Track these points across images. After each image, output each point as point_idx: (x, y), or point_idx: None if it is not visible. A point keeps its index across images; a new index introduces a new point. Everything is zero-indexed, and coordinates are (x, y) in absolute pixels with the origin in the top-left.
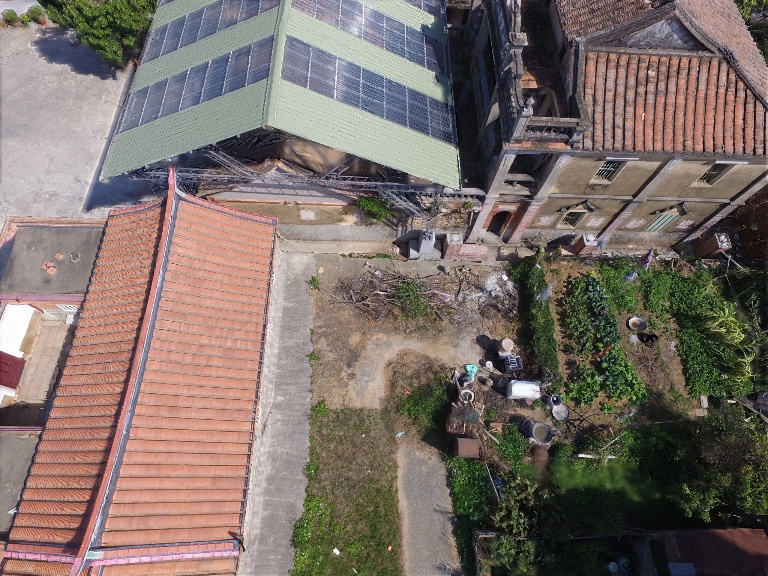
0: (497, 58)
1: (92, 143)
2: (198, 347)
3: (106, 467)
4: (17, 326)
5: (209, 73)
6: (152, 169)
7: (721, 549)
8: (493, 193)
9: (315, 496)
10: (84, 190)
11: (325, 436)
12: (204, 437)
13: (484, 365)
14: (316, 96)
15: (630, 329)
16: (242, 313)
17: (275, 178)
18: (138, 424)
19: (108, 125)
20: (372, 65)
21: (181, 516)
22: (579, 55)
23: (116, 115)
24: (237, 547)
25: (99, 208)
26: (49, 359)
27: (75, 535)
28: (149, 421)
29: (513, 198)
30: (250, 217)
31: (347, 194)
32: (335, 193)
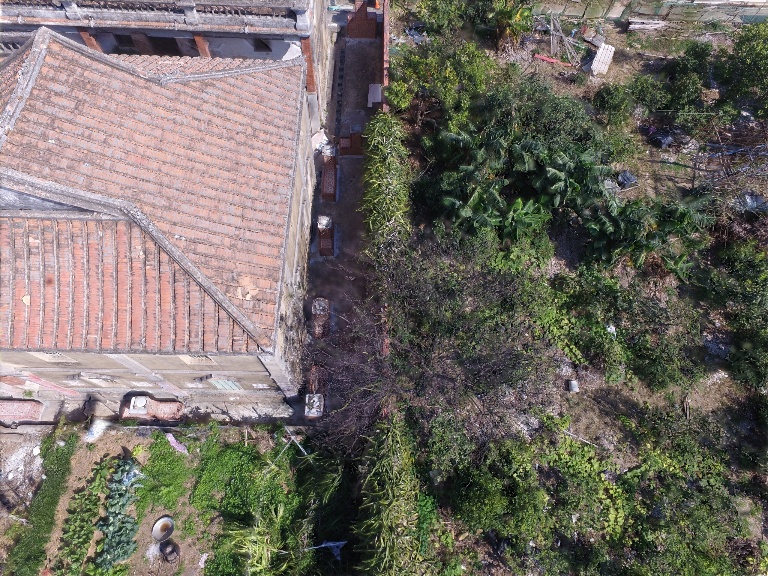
0: None
1: None
2: None
3: None
4: None
5: None
6: None
7: None
8: None
9: None
10: None
11: None
12: None
13: None
14: None
15: (153, 535)
16: None
17: None
18: None
19: None
20: None
21: None
22: None
23: None
24: None
25: None
26: None
27: None
28: None
29: None
30: None
31: None
32: None
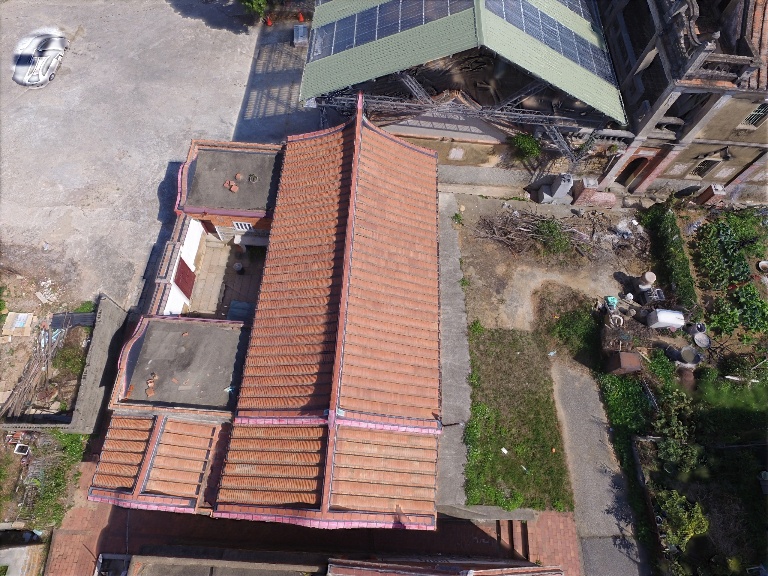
0: (660, 7)
1: (233, 90)
2: (389, 254)
3: (337, 342)
4: (193, 241)
5: (402, 8)
6: (344, 94)
7: None
8: (642, 135)
9: (481, 402)
10: (230, 131)
11: (483, 351)
12: (403, 331)
13: (623, 298)
14: (512, 27)
15: (760, 271)
16: (419, 230)
17: (453, 108)
18: (352, 312)
19: (246, 74)
20: (545, 8)
21: (394, 394)
22: (750, 1)
23: (252, 66)
24: (440, 426)
25: None
26: (215, 276)
27: (310, 400)
28: (360, 311)
29: (656, 143)
30: (417, 148)
31: (507, 130)
32: (495, 130)
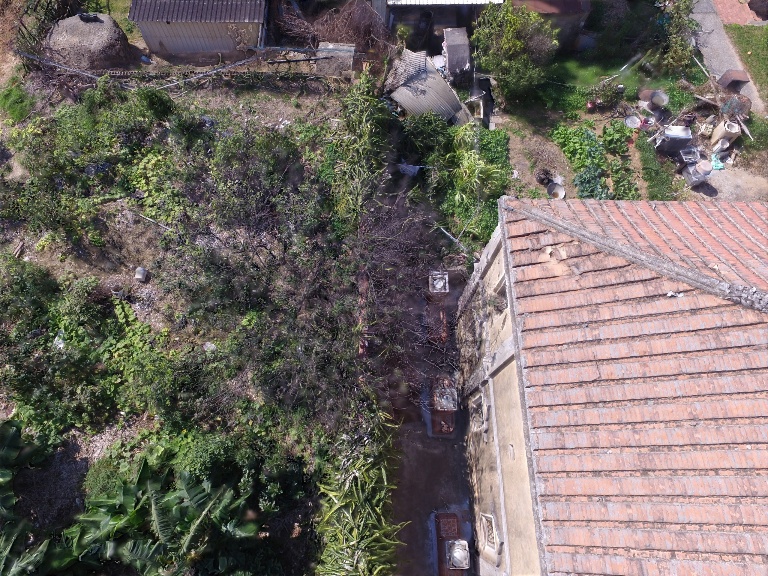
0: None
1: None
2: None
3: None
4: None
5: None
6: None
7: (547, 3)
8: None
9: None
10: None
11: None
12: None
13: None
14: None
15: None
16: None
17: None
18: None
19: None
20: None
21: None
22: None
23: None
24: None
25: None
26: None
27: None
28: None
29: None
30: None
31: None
32: None
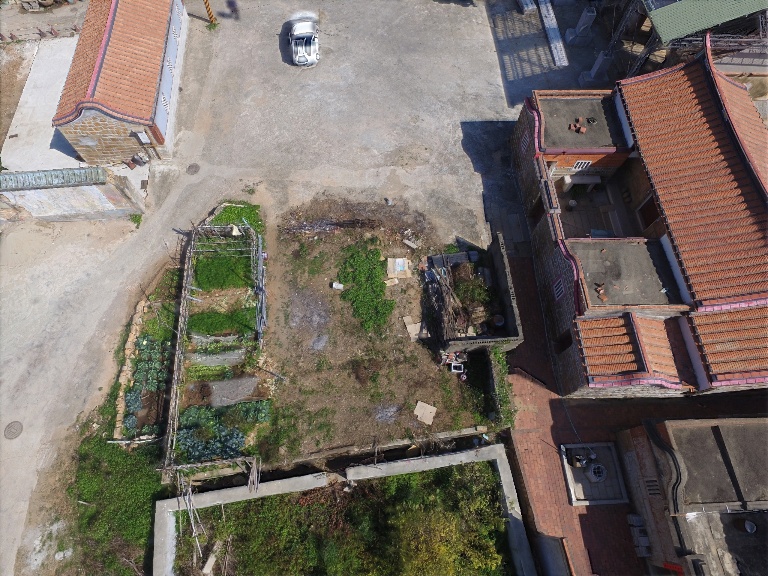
0: None
1: (486, 56)
2: (764, 168)
3: None
4: None
5: None
6: None
7: None
8: None
9: None
10: (501, 91)
11: None
12: None
13: None
14: None
15: None
16: (767, 149)
17: None
18: None
19: (491, 41)
20: None
21: None
22: None
23: (493, 34)
24: None
25: (521, 104)
26: None
27: None
28: None
29: None
30: (734, 82)
31: None
32: None
